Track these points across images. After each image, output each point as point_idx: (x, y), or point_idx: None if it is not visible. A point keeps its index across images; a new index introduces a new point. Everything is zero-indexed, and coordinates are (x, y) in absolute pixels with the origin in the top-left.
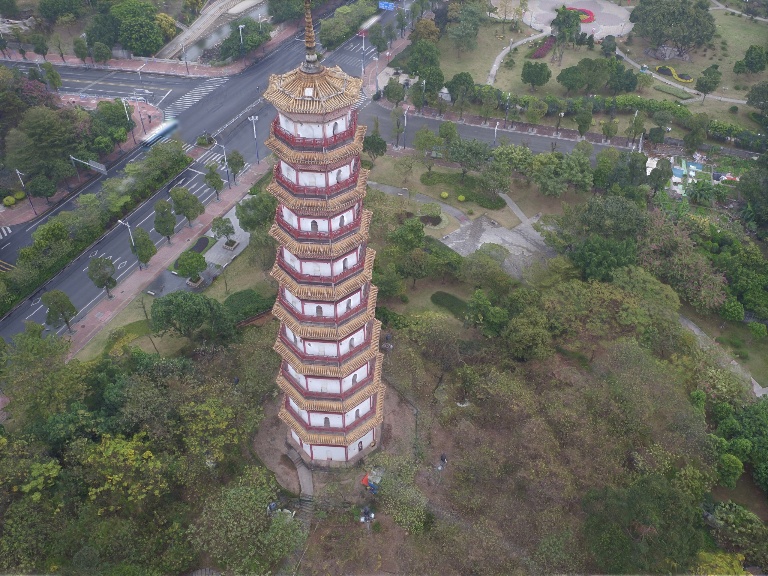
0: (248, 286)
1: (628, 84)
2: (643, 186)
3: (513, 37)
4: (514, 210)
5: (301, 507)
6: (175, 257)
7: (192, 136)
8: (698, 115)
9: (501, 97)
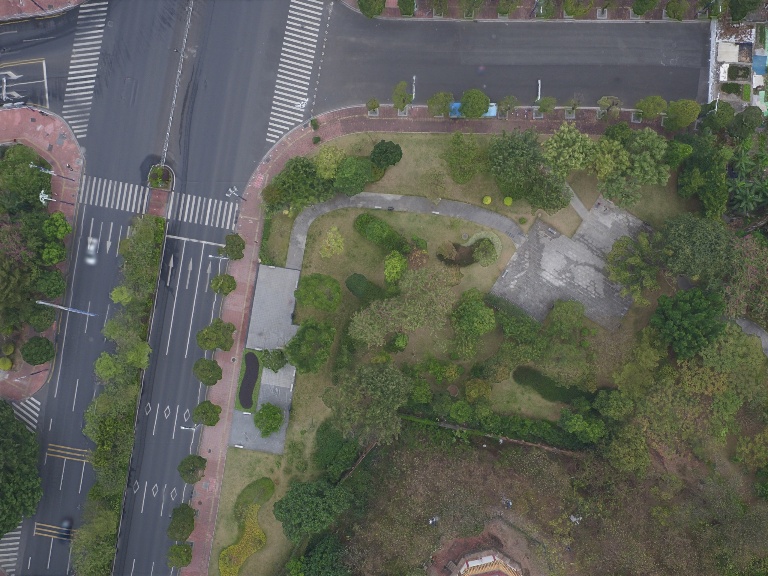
0: (329, 412)
1: None
2: (725, 151)
3: None
4: (571, 200)
5: None
6: (234, 389)
7: (135, 167)
8: None
9: None
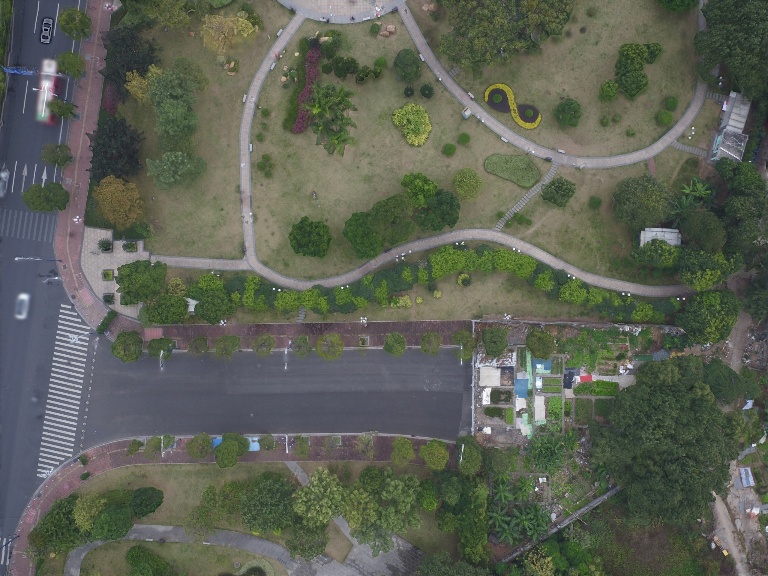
0: None
1: (445, 224)
2: (480, 490)
3: (250, 53)
4: (340, 526)
5: None
6: None
7: None
8: (541, 338)
9: (274, 305)
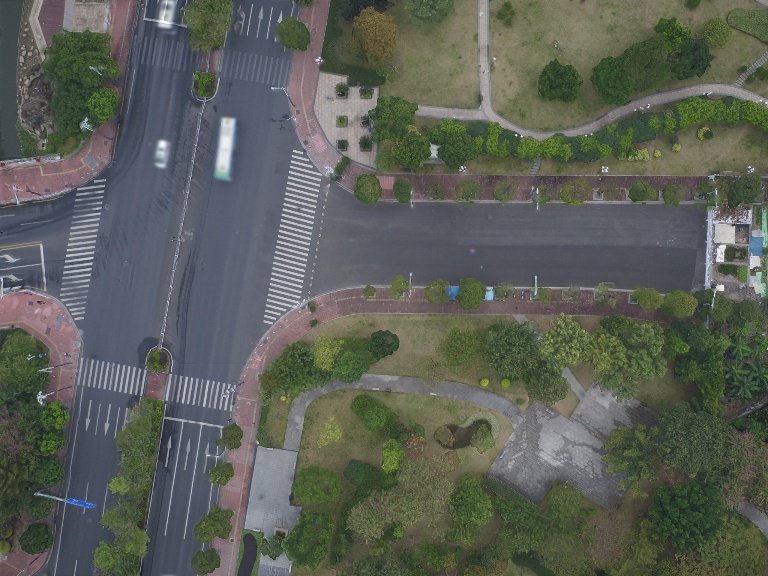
0: None
1: None
2: (722, 341)
3: None
4: (568, 381)
5: None
6: (232, 570)
7: (132, 350)
8: None
9: (516, 151)
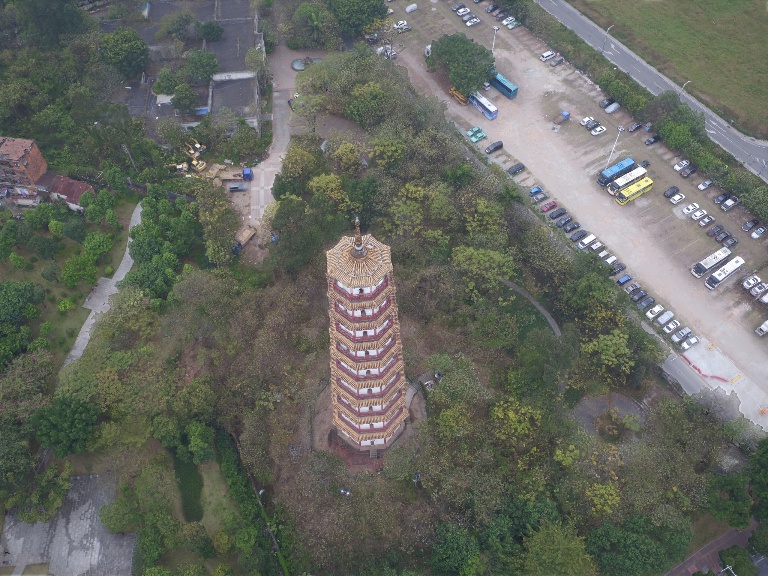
0: None
1: None
2: None
3: None
4: None
5: (419, 387)
6: None
7: None
8: None
9: None
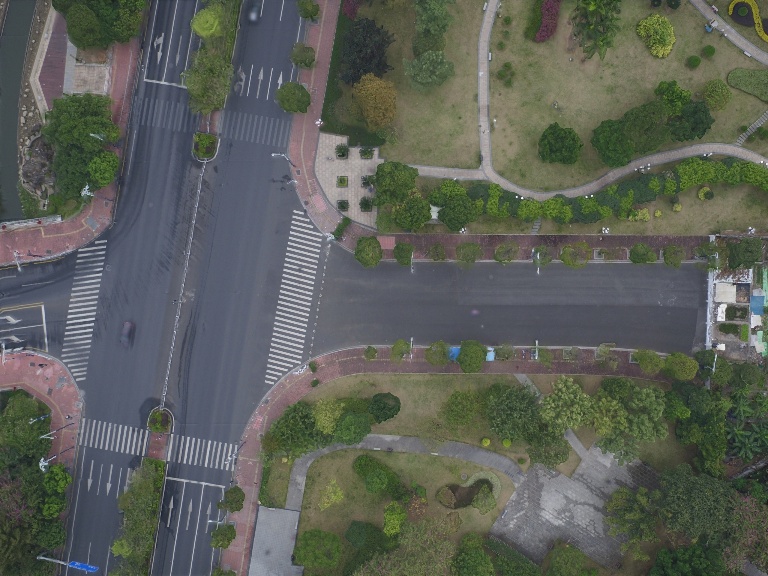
0: None
1: None
2: (723, 403)
3: None
4: (569, 440)
5: None
6: None
7: (134, 410)
8: None
9: (516, 213)
